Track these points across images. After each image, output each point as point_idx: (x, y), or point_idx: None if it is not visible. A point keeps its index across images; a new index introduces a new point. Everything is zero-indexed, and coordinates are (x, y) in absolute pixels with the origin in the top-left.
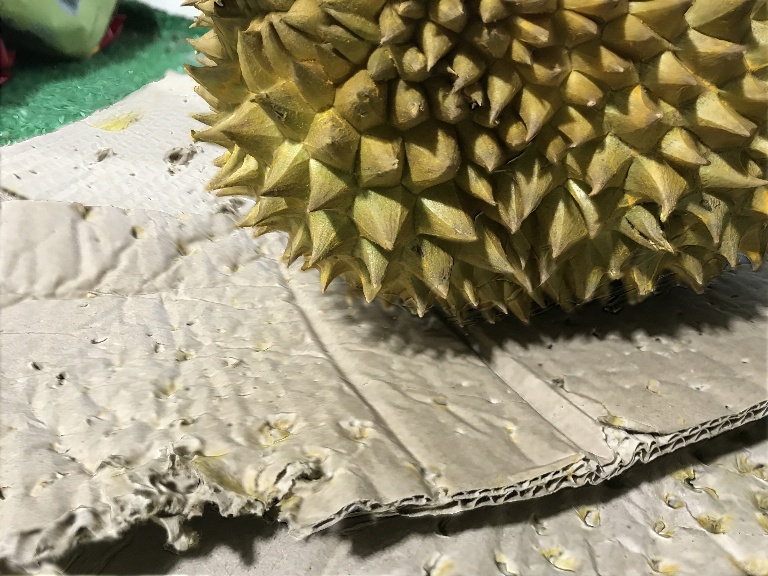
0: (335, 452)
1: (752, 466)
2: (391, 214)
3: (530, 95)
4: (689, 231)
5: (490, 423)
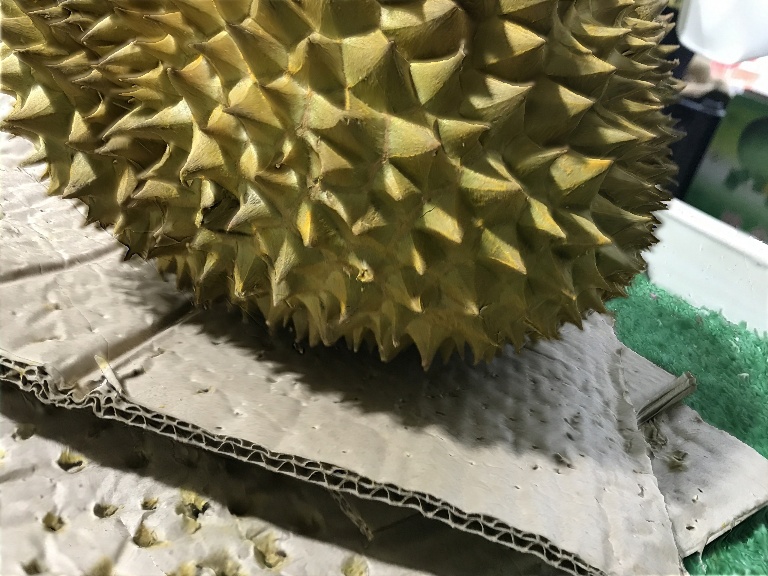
0: None
1: (276, 549)
2: (36, 106)
3: (135, 41)
4: (259, 234)
5: (52, 329)
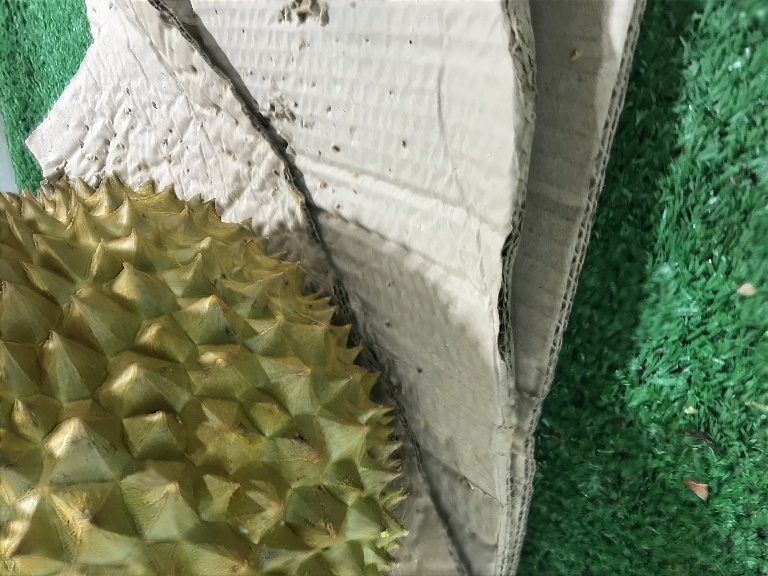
0: None
1: None
2: None
3: None
4: None
5: None
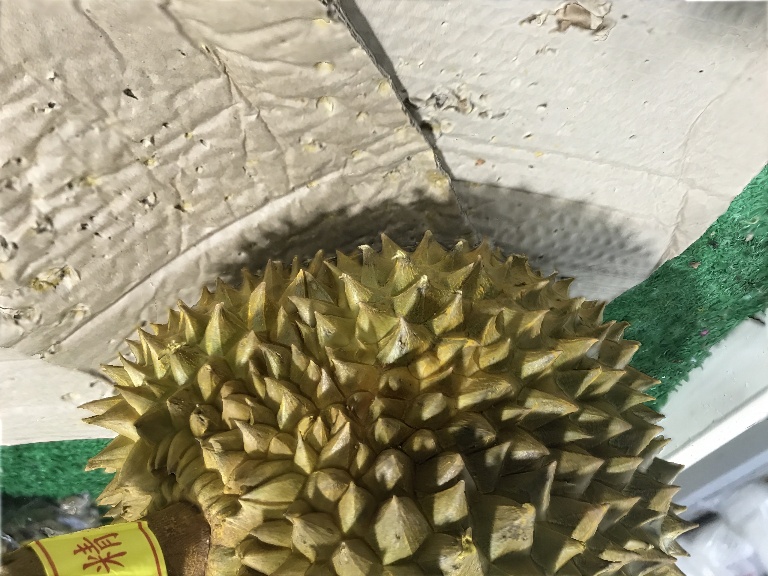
0: (36, 322)
1: None
2: None
3: None
4: None
5: None
